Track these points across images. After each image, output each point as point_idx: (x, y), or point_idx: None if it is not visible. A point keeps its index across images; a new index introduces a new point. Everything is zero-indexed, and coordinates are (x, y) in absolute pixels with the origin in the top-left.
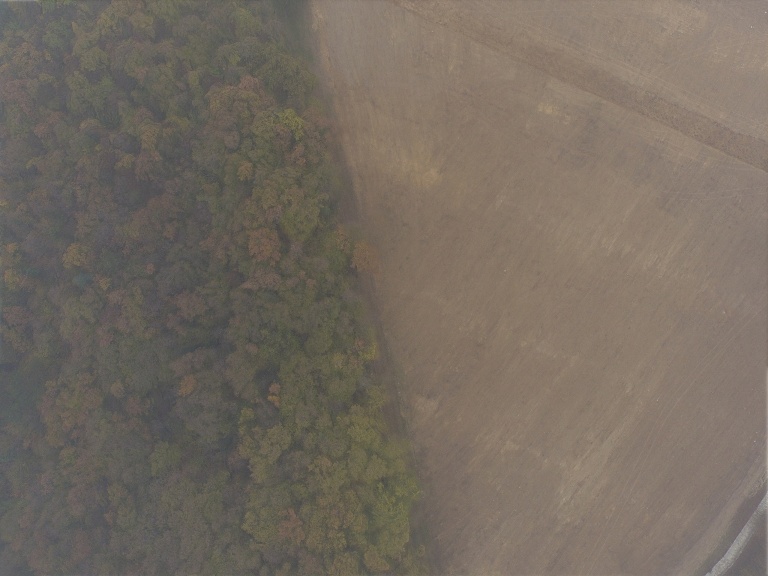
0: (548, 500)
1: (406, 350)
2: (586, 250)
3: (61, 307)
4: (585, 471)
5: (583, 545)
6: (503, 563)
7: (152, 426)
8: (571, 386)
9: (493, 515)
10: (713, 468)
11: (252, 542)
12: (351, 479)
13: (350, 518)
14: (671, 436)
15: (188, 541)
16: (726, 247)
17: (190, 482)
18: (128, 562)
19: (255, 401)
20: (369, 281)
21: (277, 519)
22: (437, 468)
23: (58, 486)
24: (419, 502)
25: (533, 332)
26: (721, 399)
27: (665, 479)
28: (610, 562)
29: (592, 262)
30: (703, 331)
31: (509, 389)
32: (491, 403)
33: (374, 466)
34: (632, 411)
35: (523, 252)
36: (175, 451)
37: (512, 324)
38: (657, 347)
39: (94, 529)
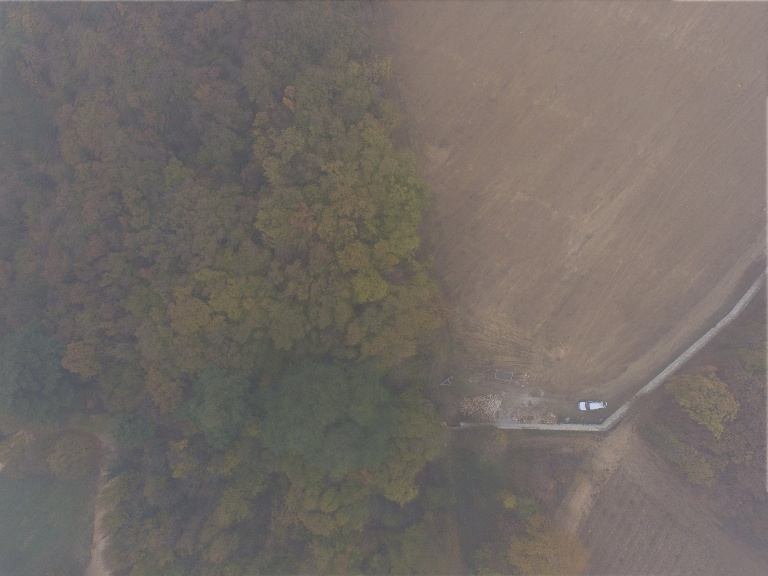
0: (556, 249)
1: (419, 101)
2: (603, 18)
3: (78, 40)
4: (594, 225)
5: (589, 294)
6: (509, 306)
7: (167, 141)
8: (583, 144)
9: (501, 260)
10: (722, 231)
11: (264, 236)
12: (363, 181)
13: (362, 204)
14: (681, 198)
15: (201, 237)
16: (744, 24)
17: (204, 189)
18: (141, 259)
19: (270, 105)
20: (384, 34)
21: (289, 212)
22: (447, 213)
23: (73, 202)
24: (428, 245)
25: (547, 91)
26: (733, 167)
27: (673, 238)
28: (615, 312)
29: (609, 29)
30: (718, 102)
31: (521, 143)
32: (503, 155)
33: (387, 164)
34: (643, 172)
35: (540, 16)
36: (189, 168)
37: (526, 83)
38: (671, 114)
39: (108, 233)
